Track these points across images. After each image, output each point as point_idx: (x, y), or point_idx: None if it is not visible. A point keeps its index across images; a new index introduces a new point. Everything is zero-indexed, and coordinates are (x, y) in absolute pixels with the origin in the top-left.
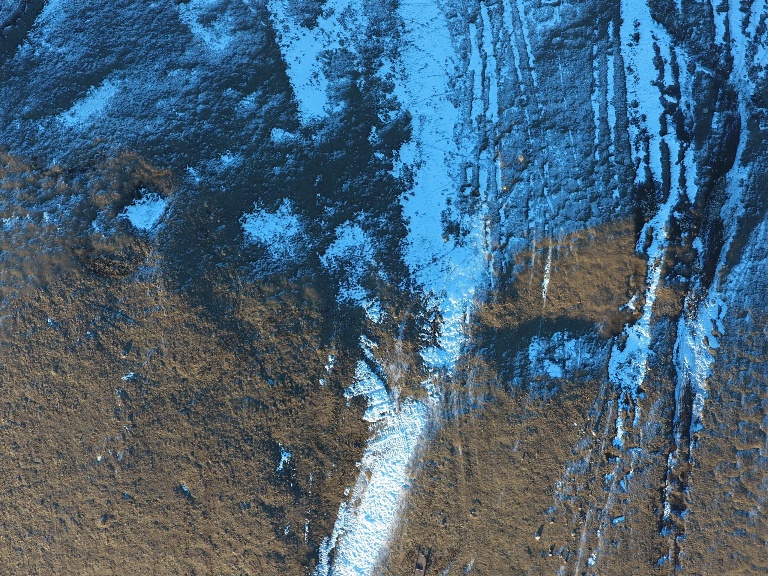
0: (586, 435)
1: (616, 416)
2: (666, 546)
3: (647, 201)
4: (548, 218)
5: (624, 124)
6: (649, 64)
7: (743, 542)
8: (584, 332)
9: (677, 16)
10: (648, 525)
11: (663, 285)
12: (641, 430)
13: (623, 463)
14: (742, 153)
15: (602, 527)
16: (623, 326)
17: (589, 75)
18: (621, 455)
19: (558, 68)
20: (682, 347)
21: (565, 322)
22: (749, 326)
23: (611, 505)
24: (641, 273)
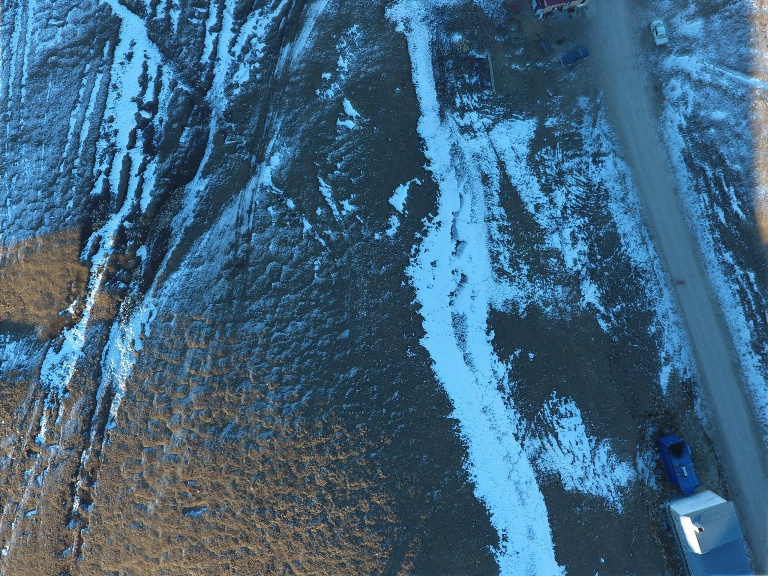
0: (12, 433)
1: (40, 415)
2: (71, 538)
3: (99, 211)
4: (4, 227)
5: (94, 138)
6: (134, 82)
7: (139, 535)
8: (25, 335)
9: (170, 36)
10: (56, 518)
11: (101, 291)
12: (62, 428)
13: (42, 459)
14: (204, 166)
15: (16, 520)
16: (61, 329)
17: (75, 92)
18: (41, 452)
19: (48, 85)
20: (111, 349)
21: (8, 325)
22: (172, 330)
23: (26, 499)
24: (83, 279)
